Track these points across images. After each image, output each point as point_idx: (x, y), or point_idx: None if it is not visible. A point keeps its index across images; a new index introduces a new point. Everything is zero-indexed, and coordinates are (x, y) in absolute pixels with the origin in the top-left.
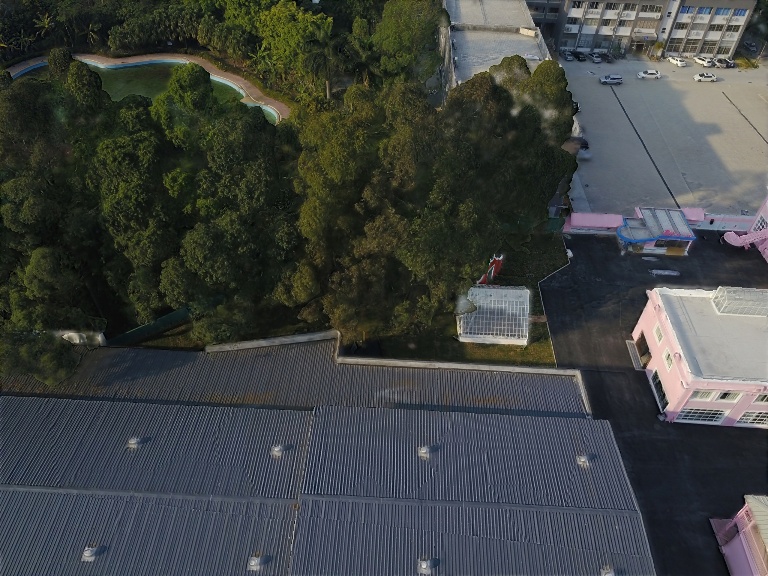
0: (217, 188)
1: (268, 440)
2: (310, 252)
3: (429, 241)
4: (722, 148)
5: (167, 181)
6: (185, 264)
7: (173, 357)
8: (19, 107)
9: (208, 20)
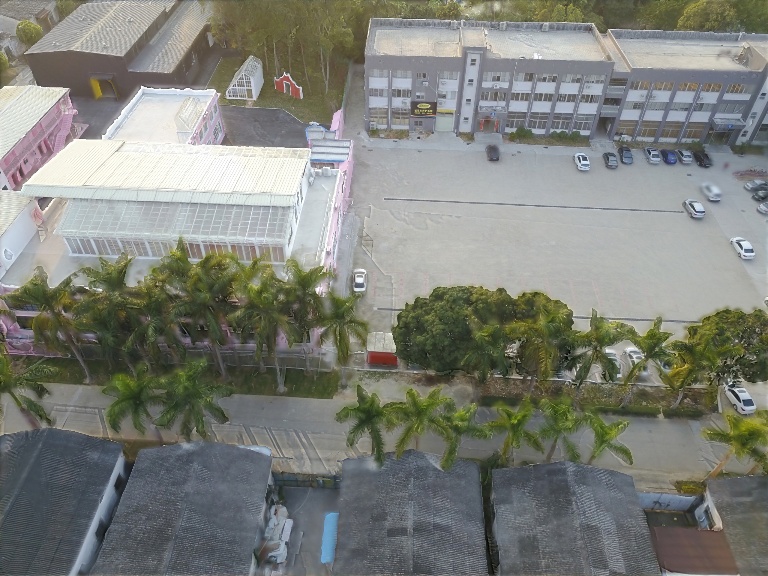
0: None
1: None
2: None
3: None
4: (531, 262)
5: None
6: None
7: None
8: None
9: None
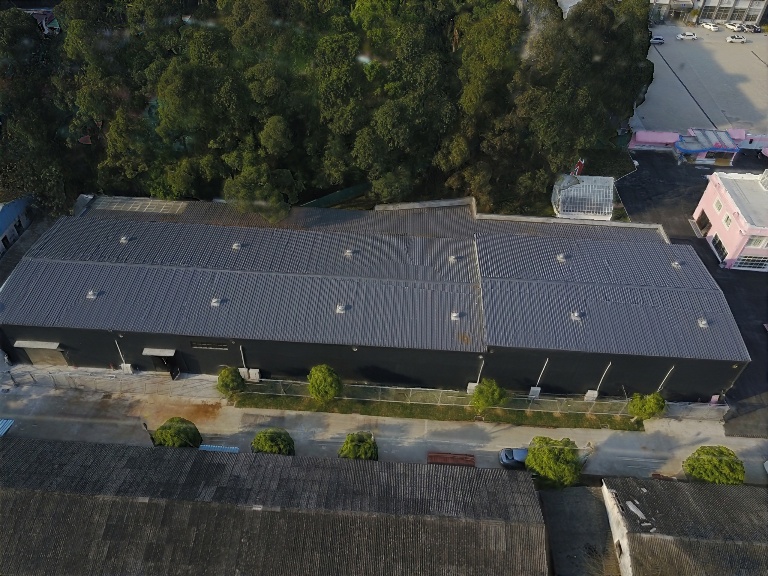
0: (402, 75)
1: (445, 253)
2: (464, 128)
3: (557, 115)
4: (754, 93)
5: (367, 68)
6: (376, 131)
7: (351, 213)
8: (271, 8)
9: None
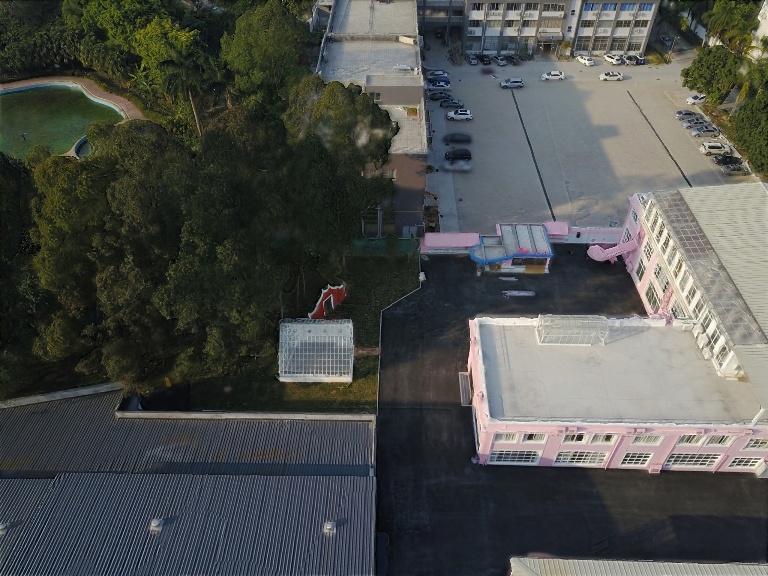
0: None
1: None
2: (66, 303)
3: (180, 288)
4: (613, 152)
5: None
6: None
7: None
8: None
9: (88, 41)
